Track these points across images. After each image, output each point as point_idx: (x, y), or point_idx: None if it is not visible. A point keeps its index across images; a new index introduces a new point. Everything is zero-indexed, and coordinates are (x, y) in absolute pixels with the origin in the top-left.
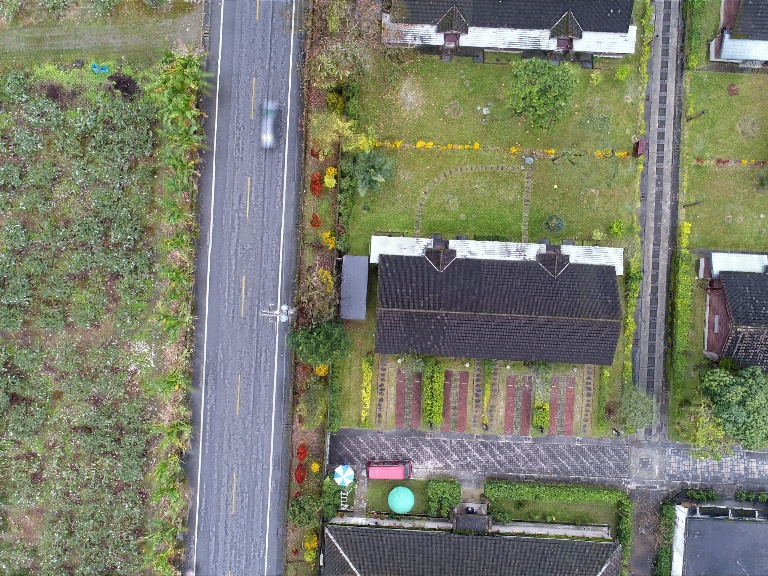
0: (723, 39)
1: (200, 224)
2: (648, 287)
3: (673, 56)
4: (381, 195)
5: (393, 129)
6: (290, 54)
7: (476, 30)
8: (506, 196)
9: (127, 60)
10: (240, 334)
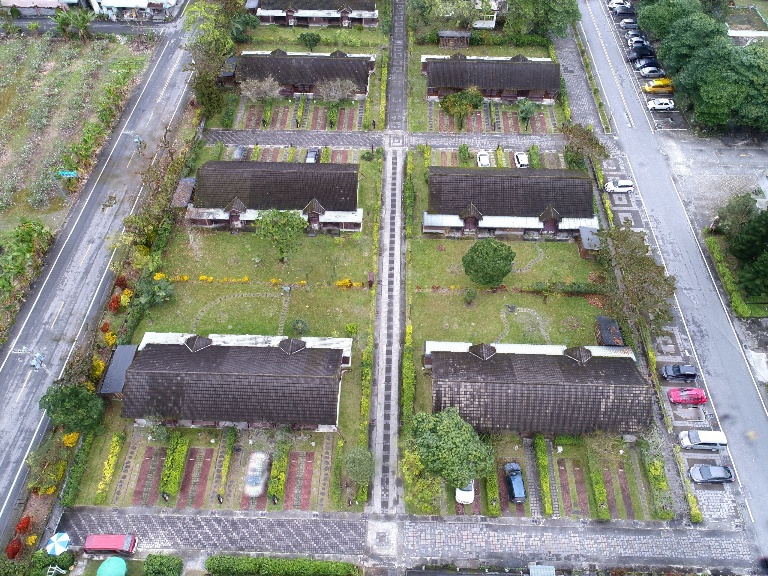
0: (423, 215)
1: (10, 333)
2: (383, 377)
3: (398, 232)
4: (166, 313)
5: (186, 272)
6: (122, 231)
7: (252, 211)
8: (267, 313)
9: (4, 237)
10: (8, 416)
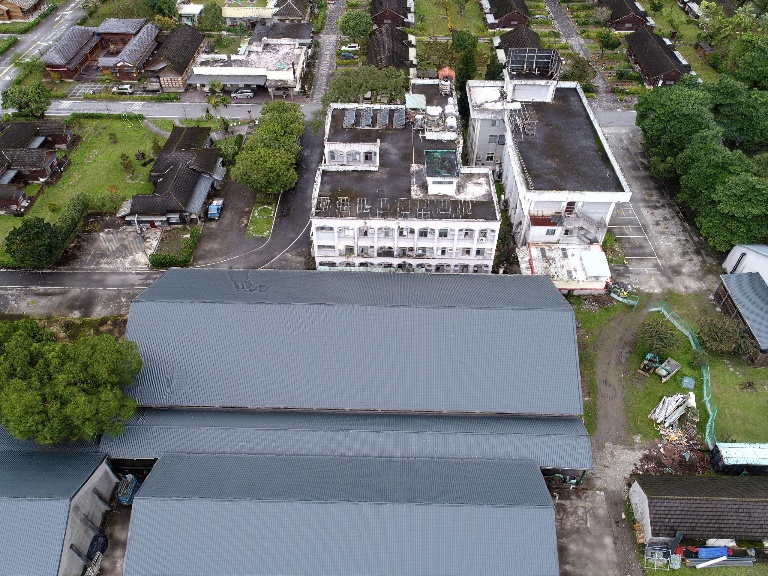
0: None
1: None
2: None
3: None
4: None
5: None
6: None
7: None
8: None
9: None
10: None
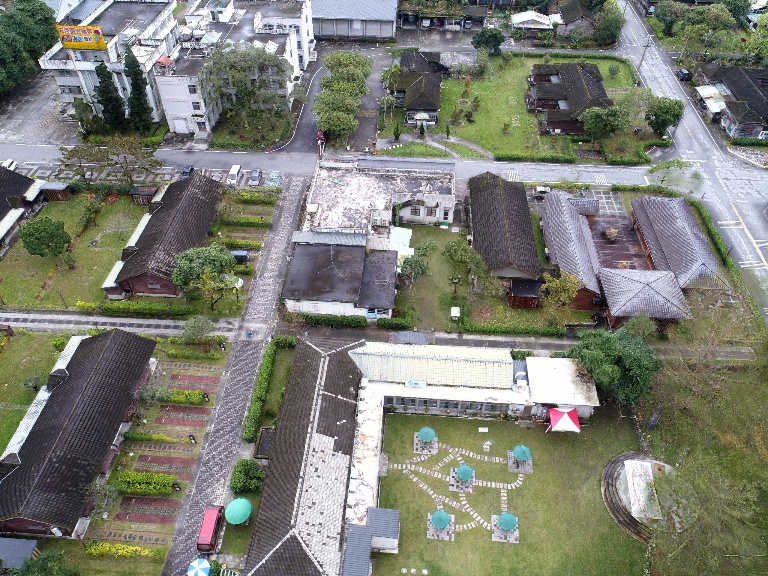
0: None
1: None
2: None
3: None
4: None
5: None
6: None
7: None
8: None
9: None
10: None
